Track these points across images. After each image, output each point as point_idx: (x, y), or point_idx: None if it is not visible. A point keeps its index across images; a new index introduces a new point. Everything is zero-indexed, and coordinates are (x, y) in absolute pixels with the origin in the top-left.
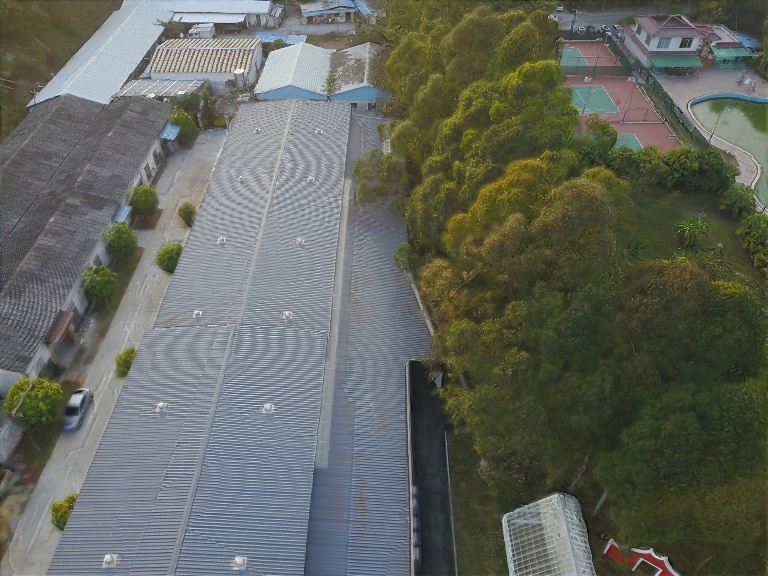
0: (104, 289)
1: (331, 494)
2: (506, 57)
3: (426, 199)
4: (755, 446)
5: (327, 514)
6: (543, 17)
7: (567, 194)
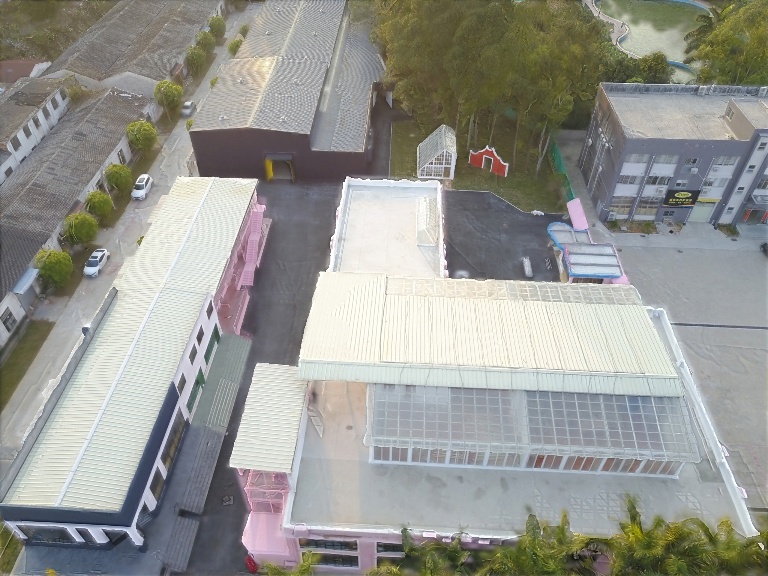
0: (199, 60)
1: (327, 119)
2: None
3: None
4: (500, 29)
5: (324, 124)
6: None
7: None
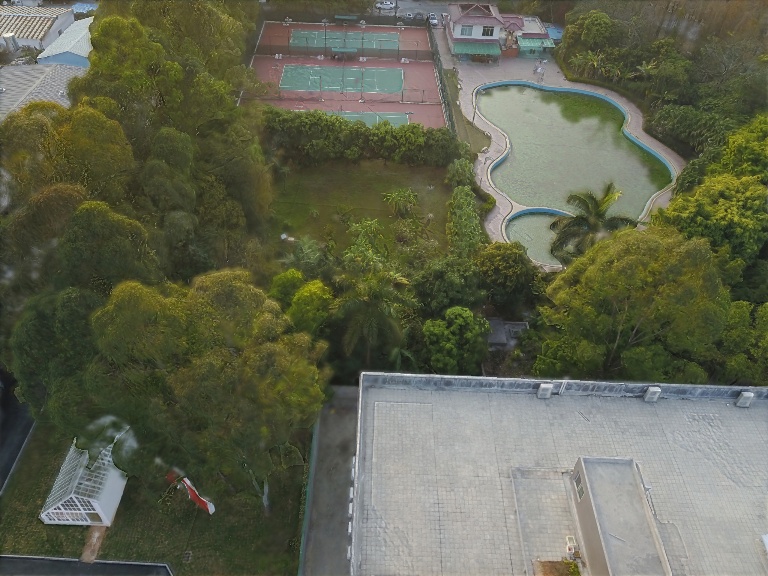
0: None
1: None
2: (134, 17)
3: None
4: (90, 343)
5: None
6: None
7: (2, 124)
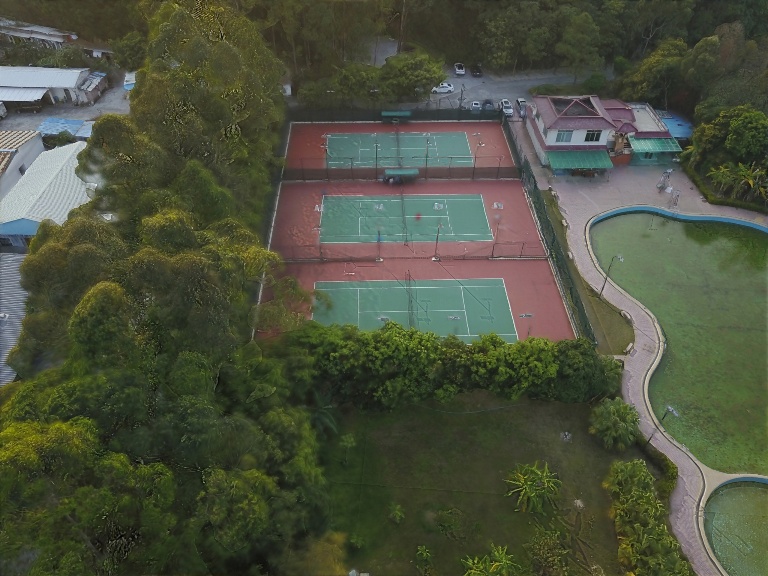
0: None
1: None
2: None
3: None
4: None
5: None
6: (147, 267)
7: None
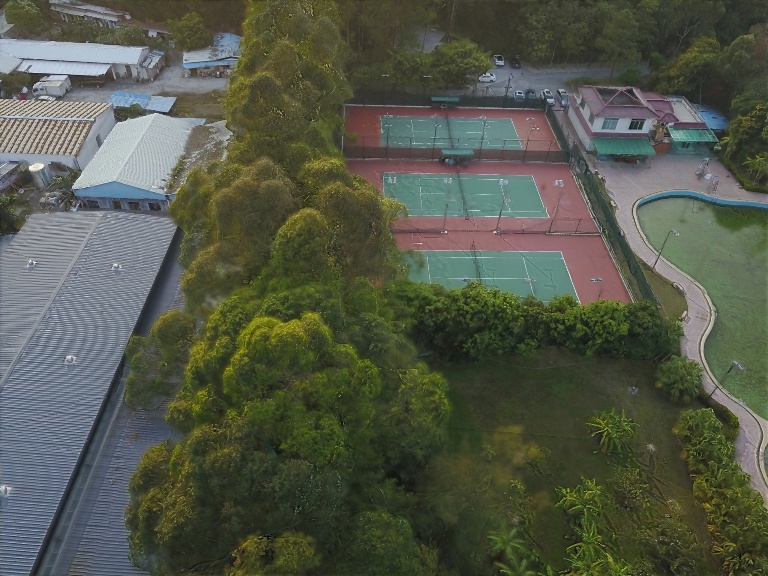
0: None
1: None
2: (280, 261)
3: (135, 498)
4: None
5: None
6: (343, 197)
7: None
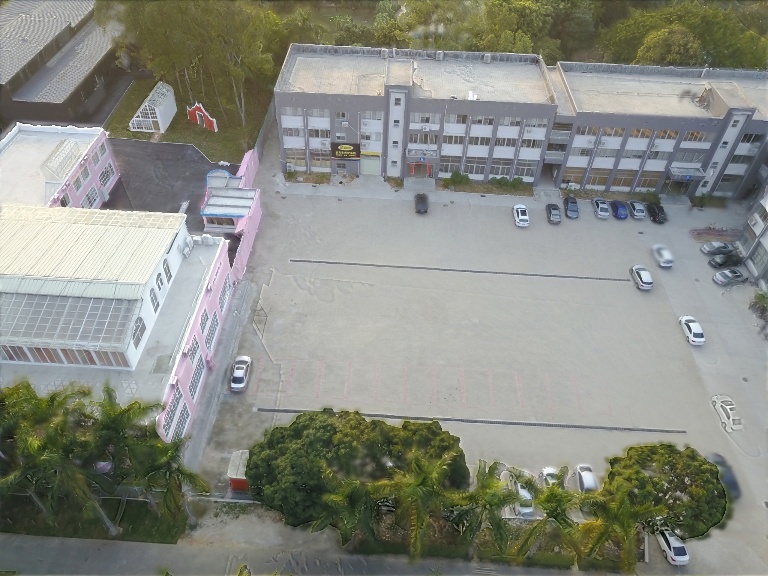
0: None
1: (48, 74)
2: None
3: None
4: None
5: (42, 78)
6: None
7: None
